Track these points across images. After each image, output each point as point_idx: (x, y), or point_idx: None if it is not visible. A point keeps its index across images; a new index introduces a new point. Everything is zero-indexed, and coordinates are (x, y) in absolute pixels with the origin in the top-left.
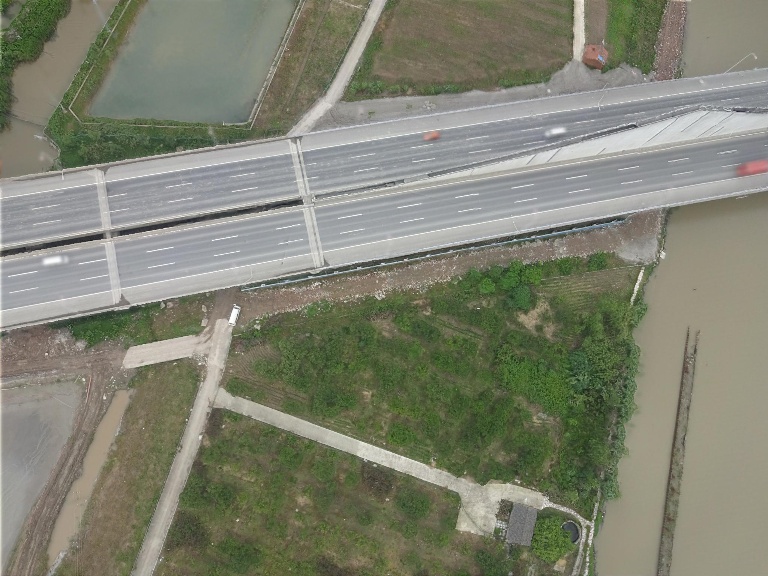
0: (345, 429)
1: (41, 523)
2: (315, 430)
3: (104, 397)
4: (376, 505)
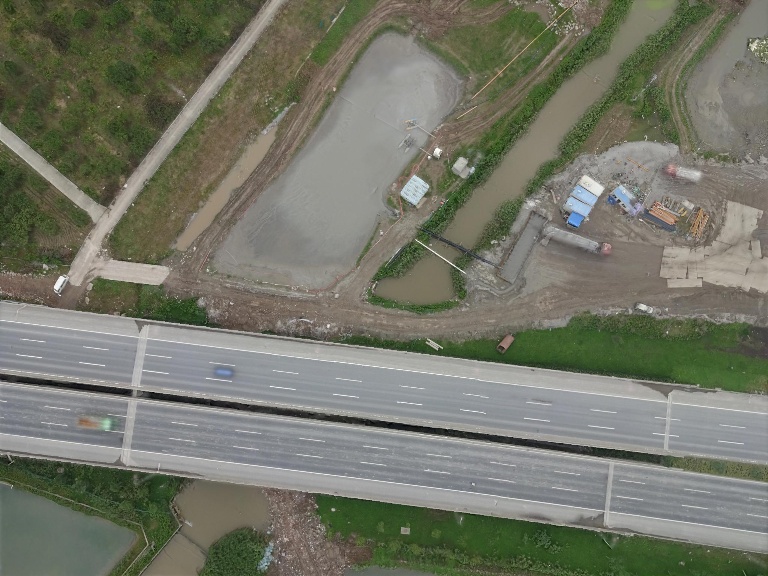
0: (4, 150)
1: (272, 162)
2: (28, 158)
3: (195, 249)
4: (2, 77)
